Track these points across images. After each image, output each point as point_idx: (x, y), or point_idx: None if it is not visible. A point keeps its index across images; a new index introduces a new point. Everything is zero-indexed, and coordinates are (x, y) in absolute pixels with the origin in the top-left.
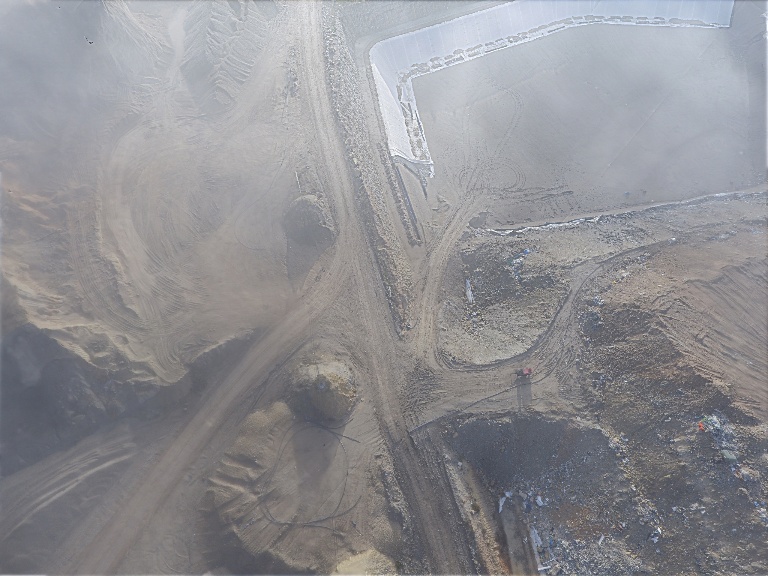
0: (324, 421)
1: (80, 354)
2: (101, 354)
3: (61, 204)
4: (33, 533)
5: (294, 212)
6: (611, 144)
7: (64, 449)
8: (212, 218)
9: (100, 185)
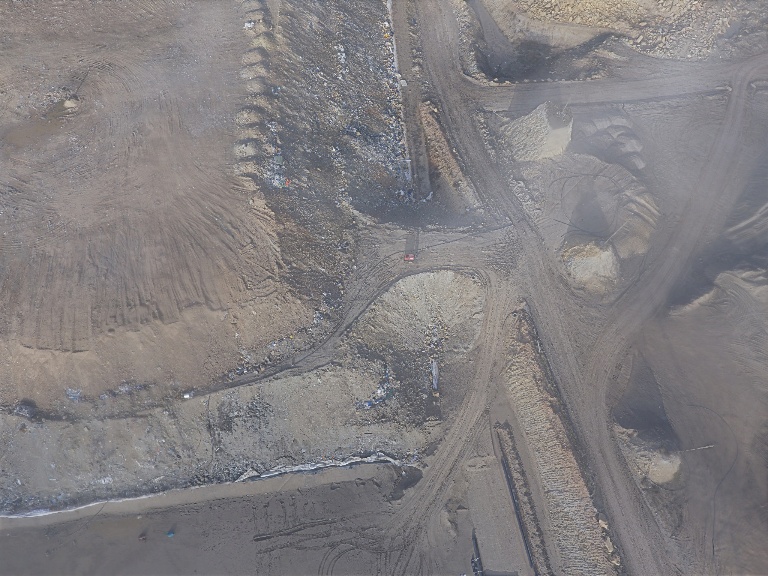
0: (587, 234)
1: None
2: None
3: None
4: None
5: None
6: None
7: None
8: None
9: None
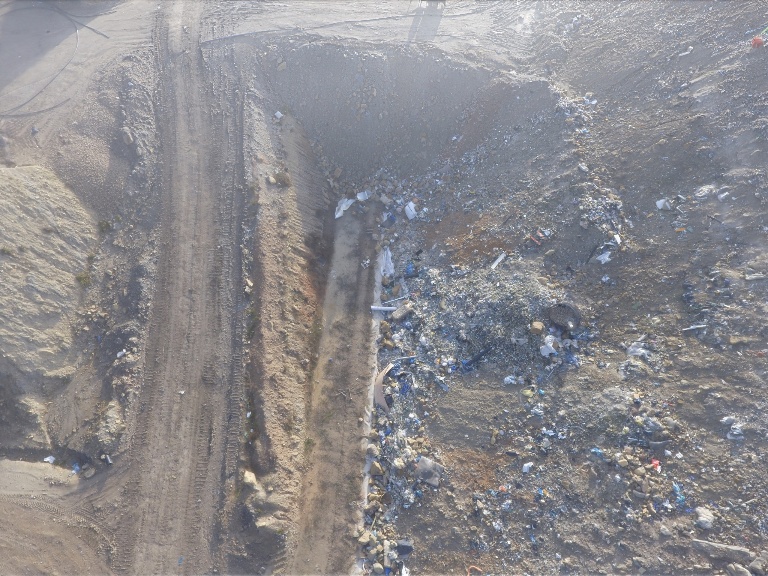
0: (63, 1)
1: None
2: None
3: None
4: None
5: None
6: None
7: None
8: None
9: None
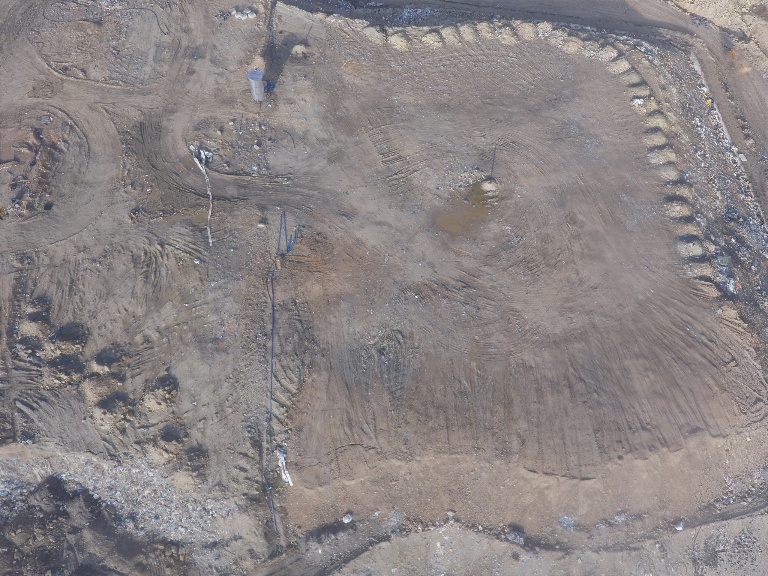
0: None
1: None
2: None
3: None
4: None
5: None
6: None
7: None
8: None
9: None
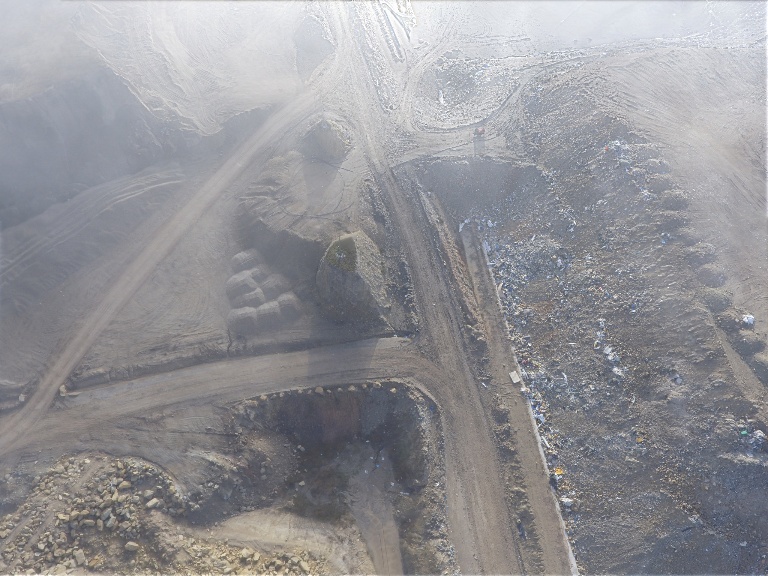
0: (326, 158)
1: (143, 104)
2: (158, 109)
3: (121, 16)
4: (114, 218)
5: (302, 26)
6: (565, 7)
7: (132, 173)
8: (237, 34)
9: (149, 8)
